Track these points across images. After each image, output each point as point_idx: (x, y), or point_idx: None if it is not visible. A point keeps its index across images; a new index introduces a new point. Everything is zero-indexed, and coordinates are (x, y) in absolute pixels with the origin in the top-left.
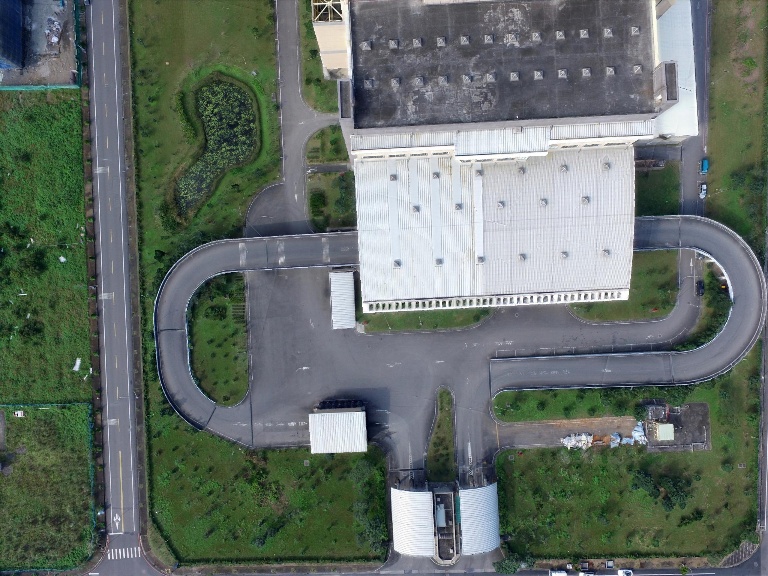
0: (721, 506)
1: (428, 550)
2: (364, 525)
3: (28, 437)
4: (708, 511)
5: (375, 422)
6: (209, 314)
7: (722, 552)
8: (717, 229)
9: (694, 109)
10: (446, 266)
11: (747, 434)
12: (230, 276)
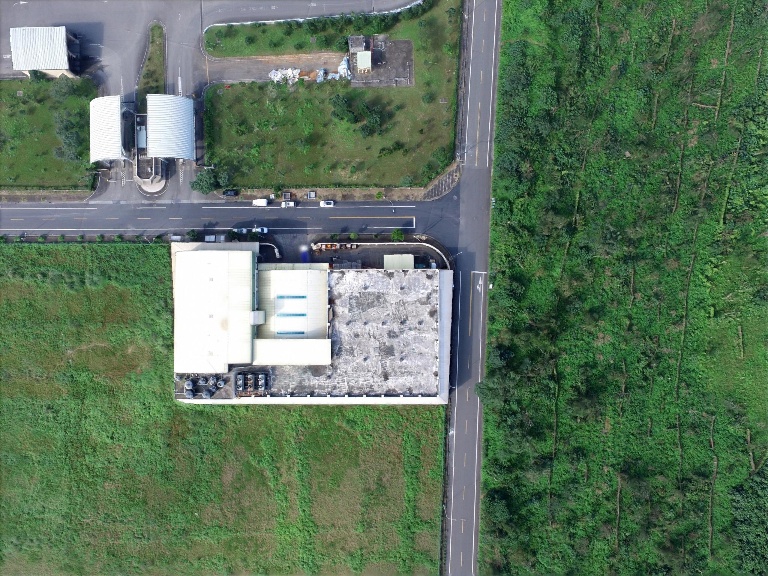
0: (422, 140)
1: (114, 152)
2: (62, 139)
3: None
4: (409, 144)
5: (88, 56)
6: None
7: (420, 182)
8: None
9: None
10: None
11: (449, 71)
12: None
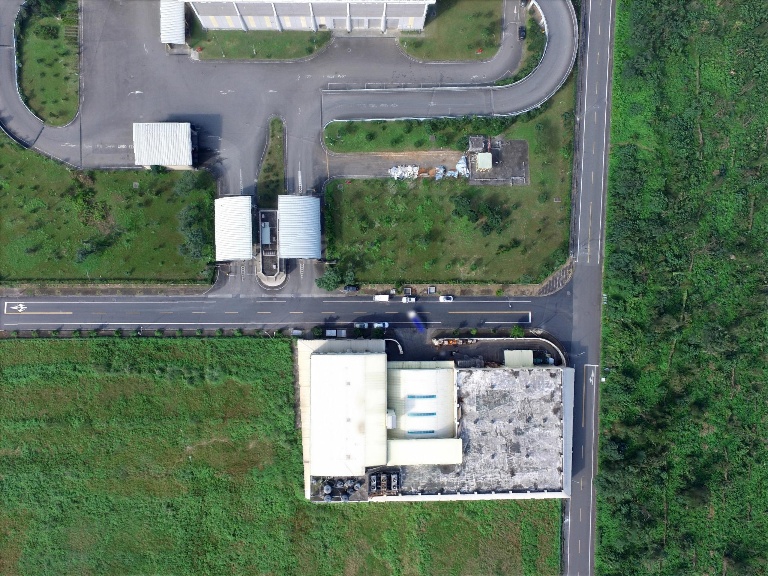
0: (537, 237)
1: (245, 252)
2: (186, 236)
3: None
4: (525, 242)
5: (207, 148)
6: (39, 31)
7: (536, 279)
8: None
9: None
10: None
11: (563, 171)
12: None
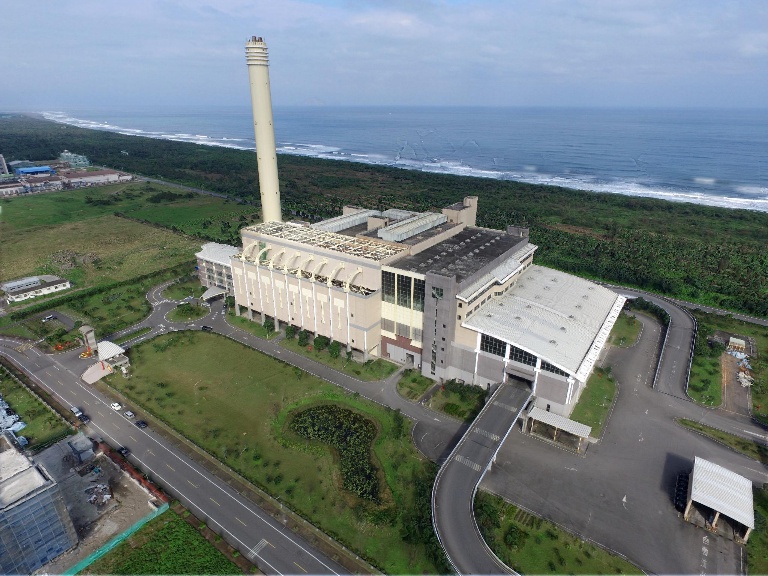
0: None
1: None
2: None
3: None
4: None
5: None
6: (514, 542)
7: None
8: None
9: None
10: (567, 330)
11: None
12: None
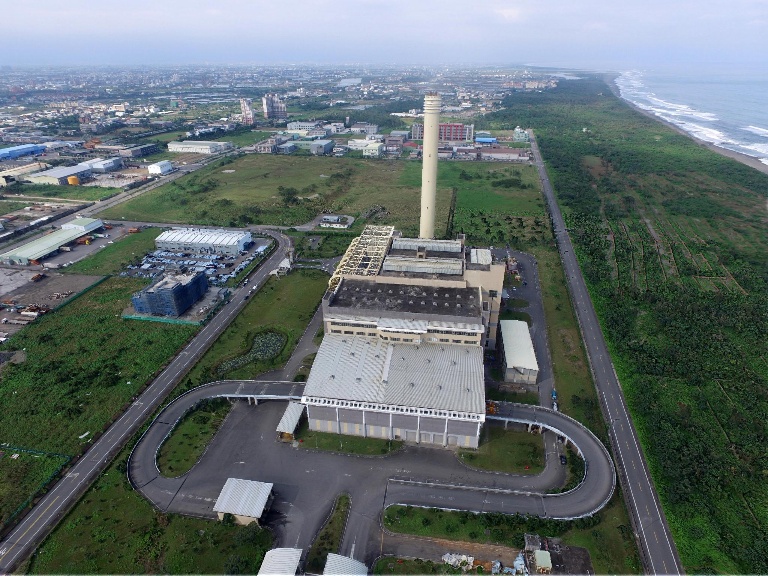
0: None
1: None
2: None
3: (3, 472)
4: None
5: (277, 511)
6: (196, 418)
7: None
8: (563, 418)
9: (534, 360)
10: (362, 383)
11: None
12: (224, 403)
